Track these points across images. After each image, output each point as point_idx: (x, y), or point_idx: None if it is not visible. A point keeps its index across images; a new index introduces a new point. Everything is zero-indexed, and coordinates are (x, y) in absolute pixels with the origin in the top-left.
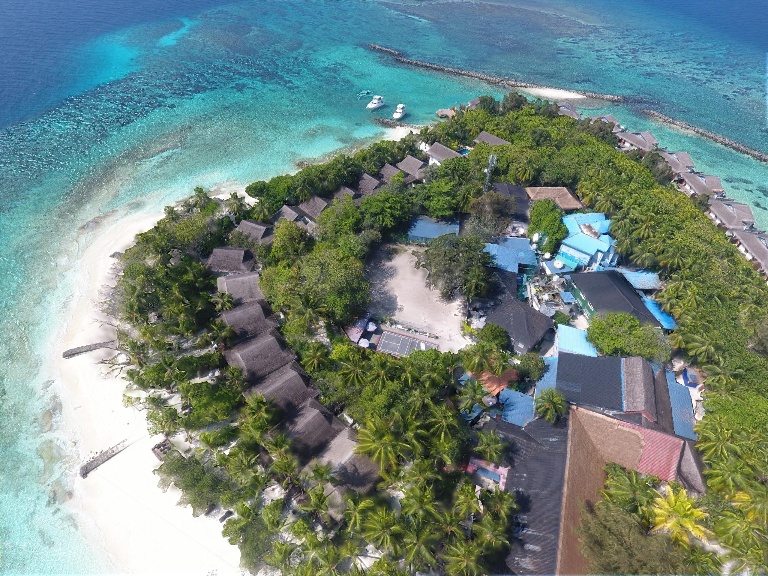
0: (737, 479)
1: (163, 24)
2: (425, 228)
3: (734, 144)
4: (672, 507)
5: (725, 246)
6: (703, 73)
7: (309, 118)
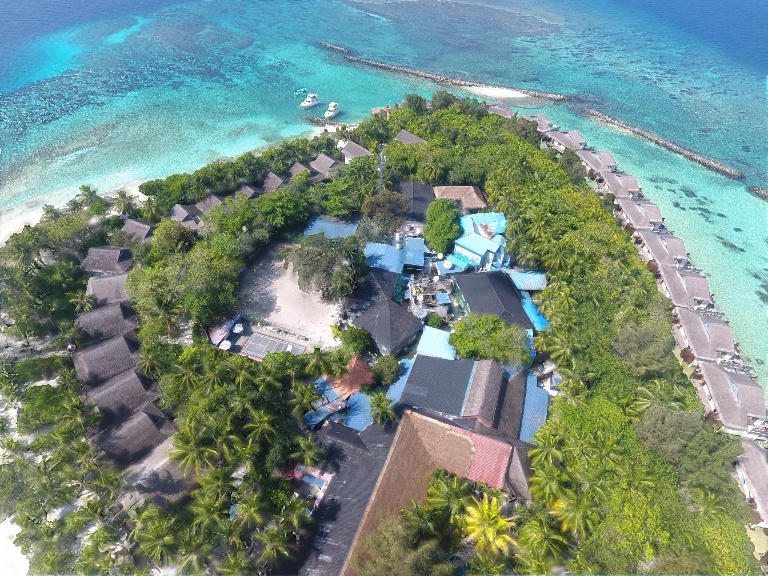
0: (553, 487)
1: (116, 22)
2: (322, 228)
3: (667, 143)
4: None
5: (620, 246)
6: (655, 72)
7: (239, 116)
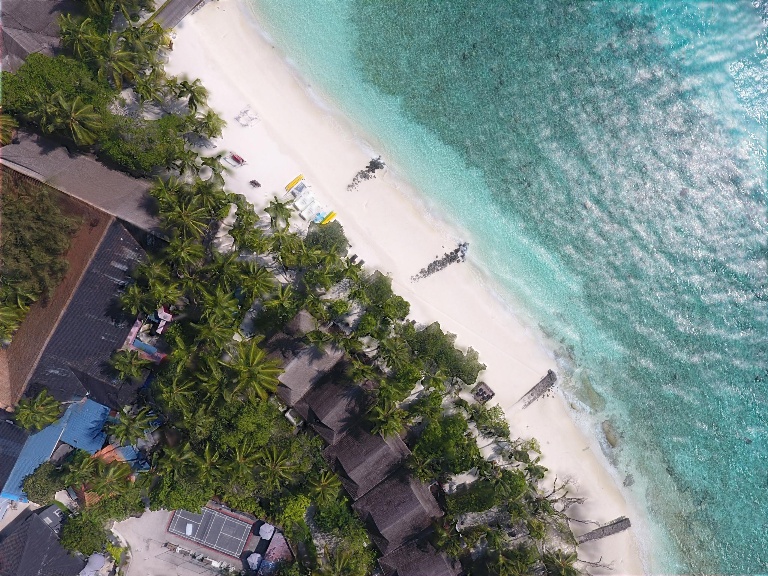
0: None
1: None
2: None
3: None
4: None
5: None
6: None
7: None
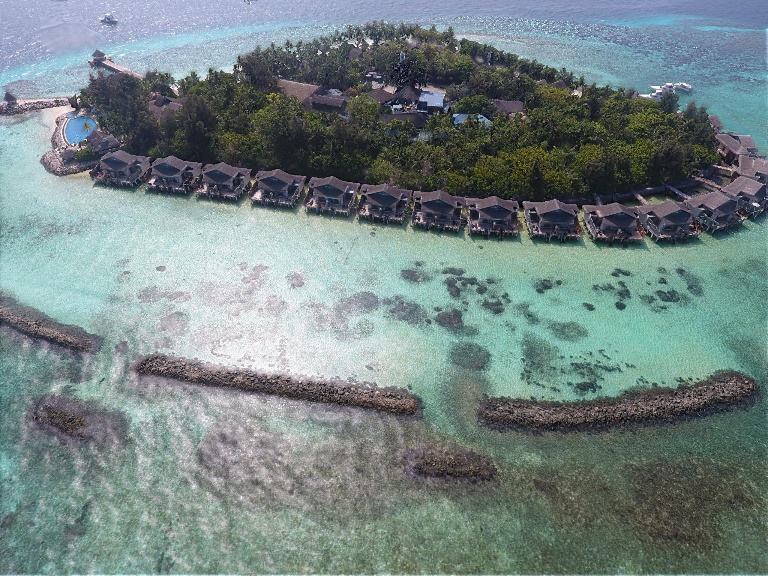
0: None
1: (748, 24)
2: None
3: None
4: None
5: None
6: None
7: (610, 72)
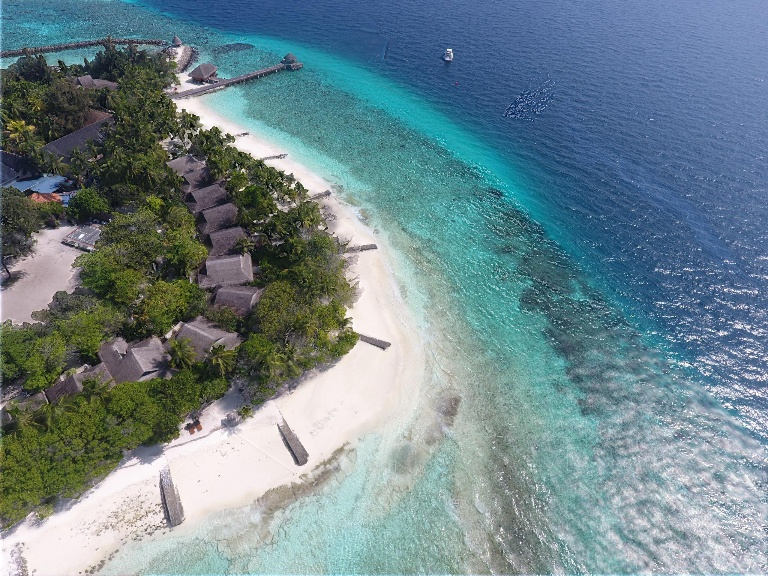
0: None
1: None
2: None
3: None
4: (19, 132)
5: None
6: None
7: None
